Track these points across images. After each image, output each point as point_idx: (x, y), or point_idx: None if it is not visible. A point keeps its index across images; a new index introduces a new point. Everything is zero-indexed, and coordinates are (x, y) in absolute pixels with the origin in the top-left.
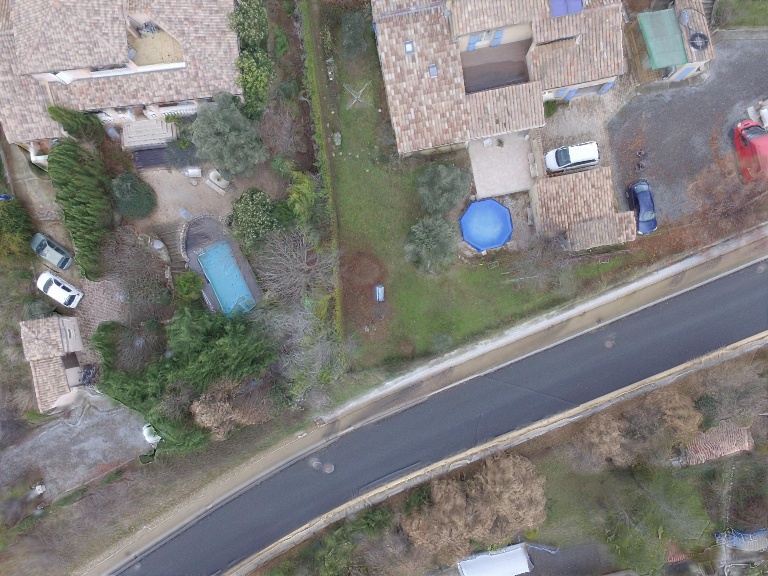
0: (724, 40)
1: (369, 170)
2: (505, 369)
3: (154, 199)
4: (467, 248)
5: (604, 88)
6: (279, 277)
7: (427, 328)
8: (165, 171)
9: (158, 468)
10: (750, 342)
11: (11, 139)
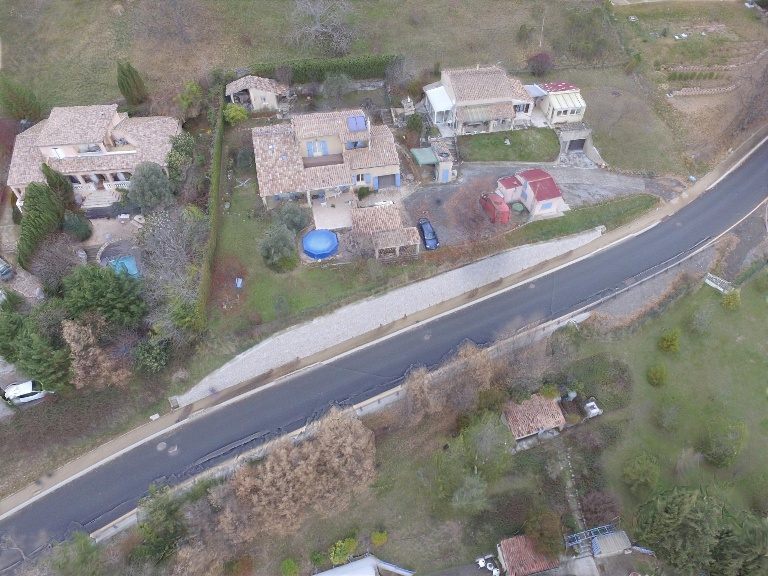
0: (469, 167)
1: (245, 220)
2: (343, 358)
3: (90, 227)
4: (308, 259)
5: (396, 180)
6: None
7: (272, 305)
8: (105, 218)
9: (4, 424)
10: (535, 327)
11: (10, 182)
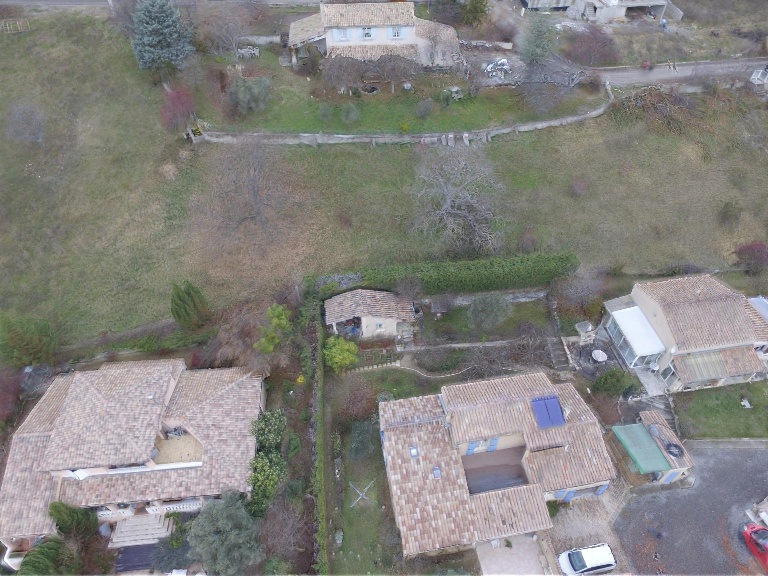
0: (695, 448)
1: (371, 572)
2: None
3: None
4: None
5: (600, 489)
6: None
7: None
8: (147, 570)
9: None
10: None
11: None
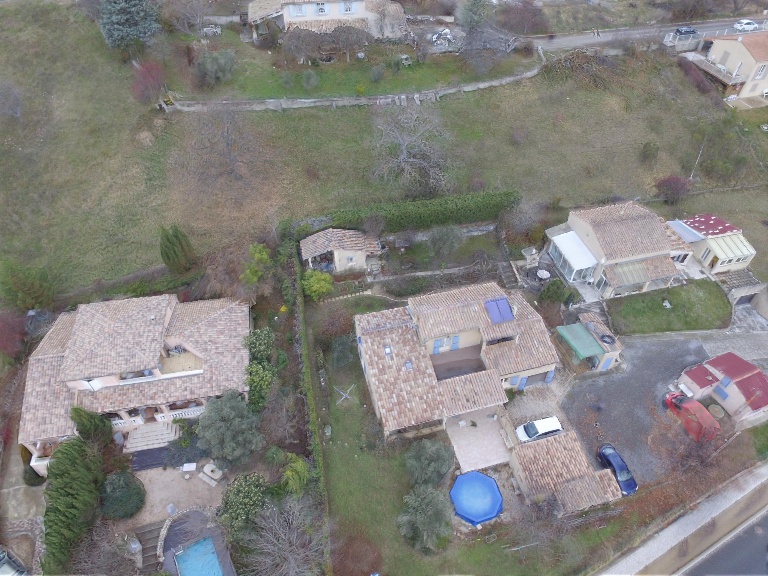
0: (627, 343)
1: (357, 455)
2: None
3: (142, 494)
4: (461, 523)
5: (548, 376)
6: (263, 570)
7: None
8: (160, 468)
9: None
10: None
11: (22, 439)
